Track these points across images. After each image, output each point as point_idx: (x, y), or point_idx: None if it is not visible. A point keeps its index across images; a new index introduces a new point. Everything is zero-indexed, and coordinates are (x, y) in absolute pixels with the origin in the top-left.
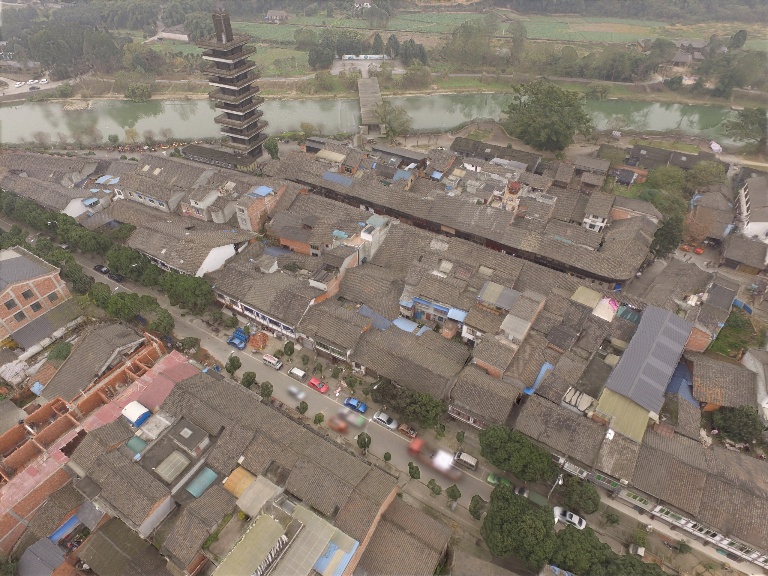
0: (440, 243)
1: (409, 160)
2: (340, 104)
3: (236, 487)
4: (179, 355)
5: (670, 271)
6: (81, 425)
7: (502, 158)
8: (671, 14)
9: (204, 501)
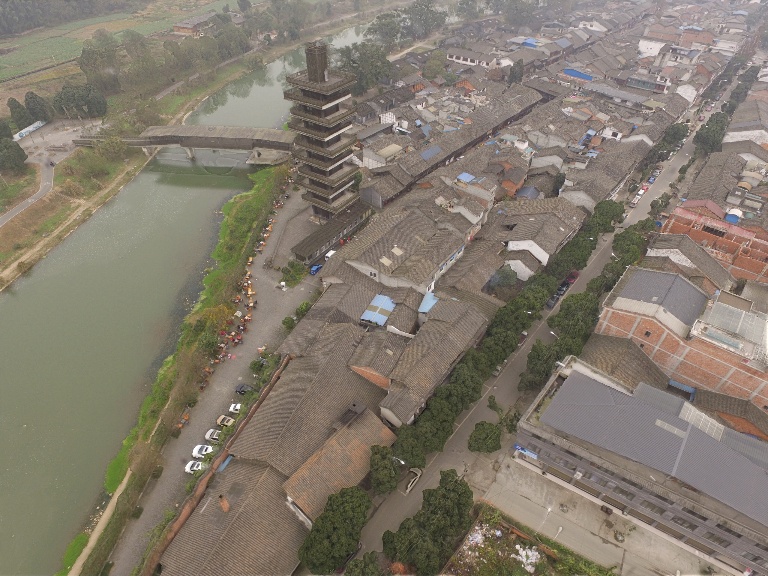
0: (525, 127)
1: (387, 130)
2: (159, 172)
3: (749, 186)
4: (676, 210)
5: (537, 85)
6: (753, 239)
7: (398, 99)
8: (120, 4)
9: (764, 191)
